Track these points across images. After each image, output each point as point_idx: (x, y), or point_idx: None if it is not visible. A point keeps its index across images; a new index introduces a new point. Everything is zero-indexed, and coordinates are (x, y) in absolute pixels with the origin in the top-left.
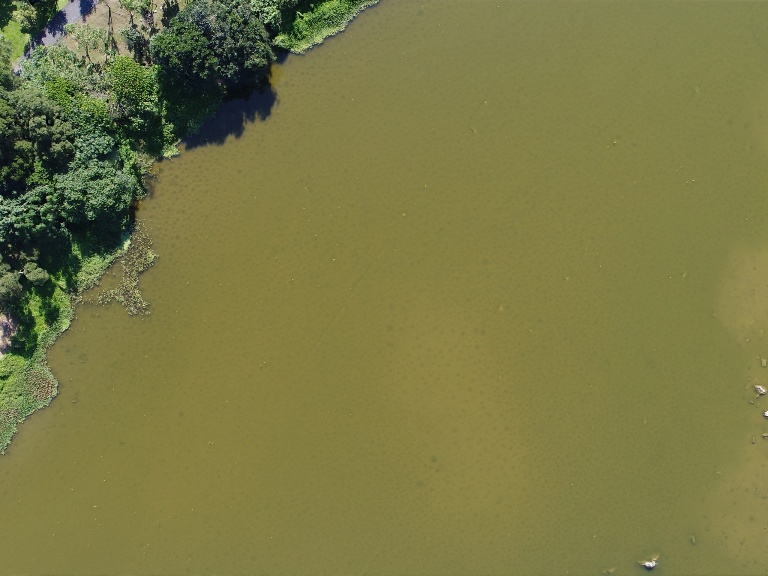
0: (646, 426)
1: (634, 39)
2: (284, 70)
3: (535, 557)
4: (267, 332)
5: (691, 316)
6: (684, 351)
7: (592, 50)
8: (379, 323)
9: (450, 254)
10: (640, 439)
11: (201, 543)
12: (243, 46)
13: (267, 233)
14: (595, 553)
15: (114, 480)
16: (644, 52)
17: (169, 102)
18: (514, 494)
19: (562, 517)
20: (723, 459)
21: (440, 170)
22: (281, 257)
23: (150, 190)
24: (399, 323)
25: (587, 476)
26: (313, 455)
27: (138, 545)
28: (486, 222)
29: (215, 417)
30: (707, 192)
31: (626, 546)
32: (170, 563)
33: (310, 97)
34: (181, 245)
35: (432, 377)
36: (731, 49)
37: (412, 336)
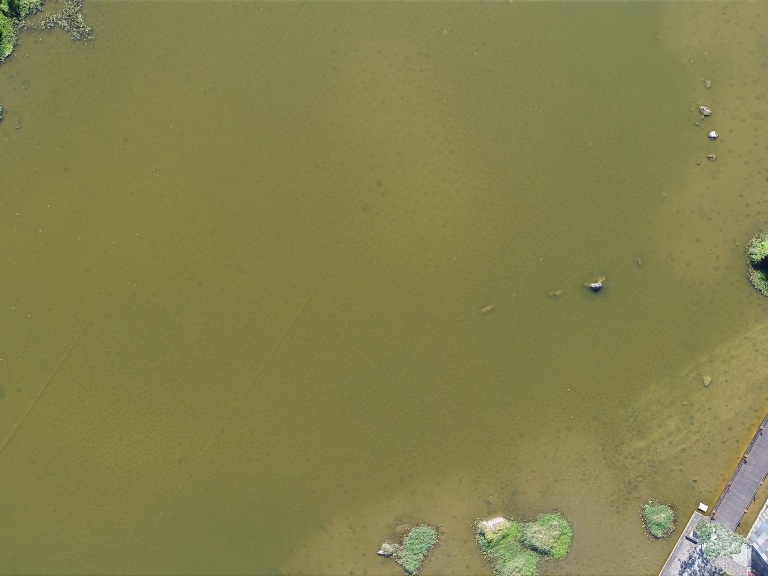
0: (591, 149)
1: None
2: None
3: (481, 280)
4: (211, 57)
5: (635, 39)
6: (628, 73)
7: None
8: (323, 47)
9: None
10: (585, 161)
11: (147, 269)
12: None
13: None
14: (541, 276)
15: (59, 206)
16: None
17: None
18: (460, 217)
19: (508, 240)
20: (668, 181)
21: None
22: None
23: None
24: (343, 47)
25: (532, 199)
26: (258, 180)
27: (83, 271)
28: None
29: (159, 142)
30: None
31: (572, 269)
32: (116, 289)
33: None
34: None
35: (376, 101)
36: None
37: (356, 60)
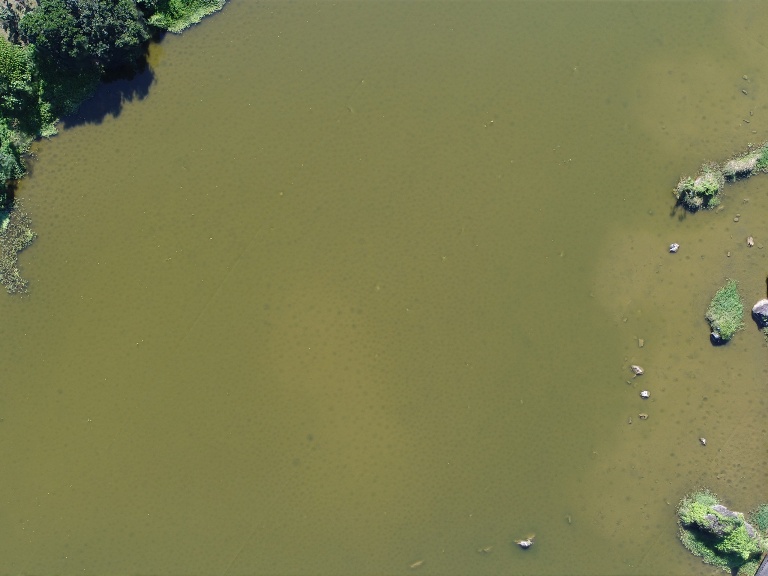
0: (523, 406)
1: (512, 18)
2: (162, 49)
3: (411, 535)
4: (145, 311)
5: (568, 296)
6: (561, 331)
7: (469, 29)
8: (256, 302)
9: (327, 233)
10: (516, 419)
11: (80, 519)
12: (112, 24)
13: (145, 212)
14: (471, 532)
15: None
16: (522, 31)
17: (46, 81)
18: (390, 473)
19: (438, 496)
20: (600, 439)
21: (317, 149)
22: (159, 236)
23: (29, 169)
24: (276, 302)
25: (463, 455)
26: (190, 433)
27: (17, 521)
28: (363, 201)
29: (93, 395)
30: (585, 172)
31: (502, 525)
32: (49, 539)
33: (188, 76)
34: (60, 224)
35: (309, 356)
36: (610, 28)
37: (289, 315)
